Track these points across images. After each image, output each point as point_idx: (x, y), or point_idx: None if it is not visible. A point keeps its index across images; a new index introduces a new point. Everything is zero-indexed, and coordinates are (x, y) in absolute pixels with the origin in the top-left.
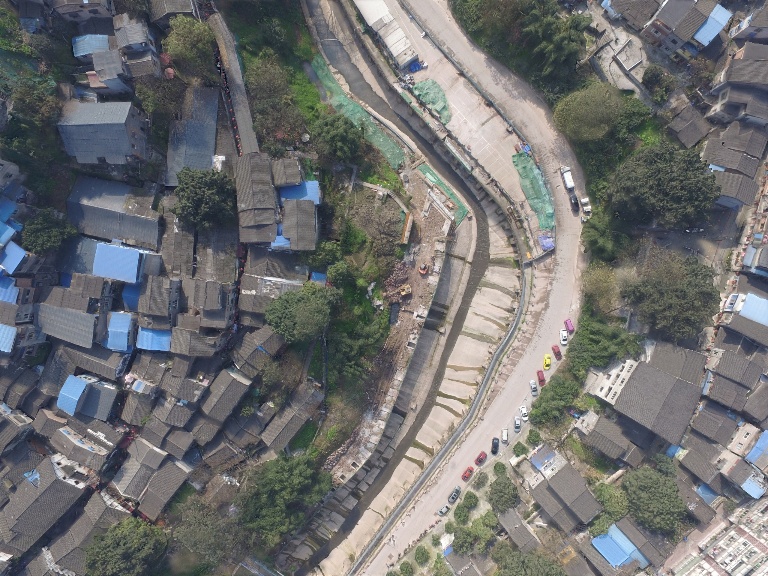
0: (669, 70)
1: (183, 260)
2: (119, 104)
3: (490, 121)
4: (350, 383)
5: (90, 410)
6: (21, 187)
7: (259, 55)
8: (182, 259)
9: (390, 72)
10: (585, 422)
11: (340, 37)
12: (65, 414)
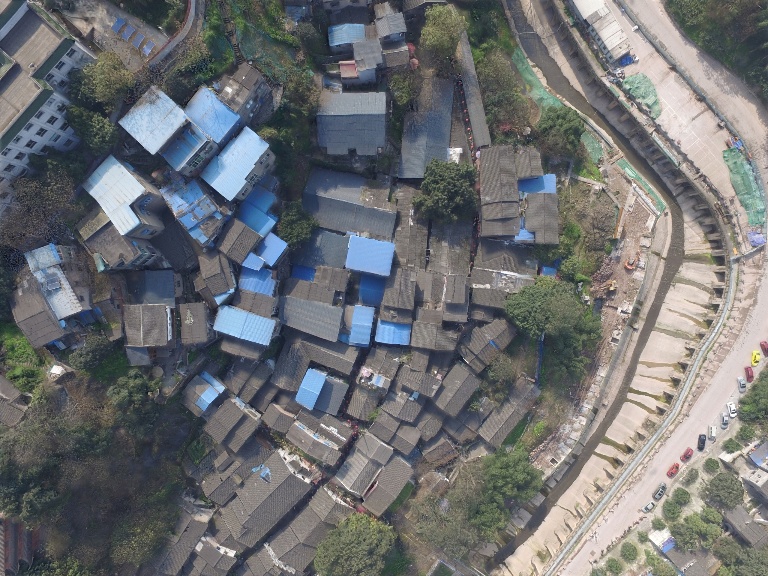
0: None
1: (417, 253)
2: (373, 94)
3: (701, 116)
4: (557, 379)
5: (323, 405)
6: (274, 178)
7: (482, 47)
8: (416, 252)
9: (598, 66)
10: None
11: (538, 30)
12: (292, 409)
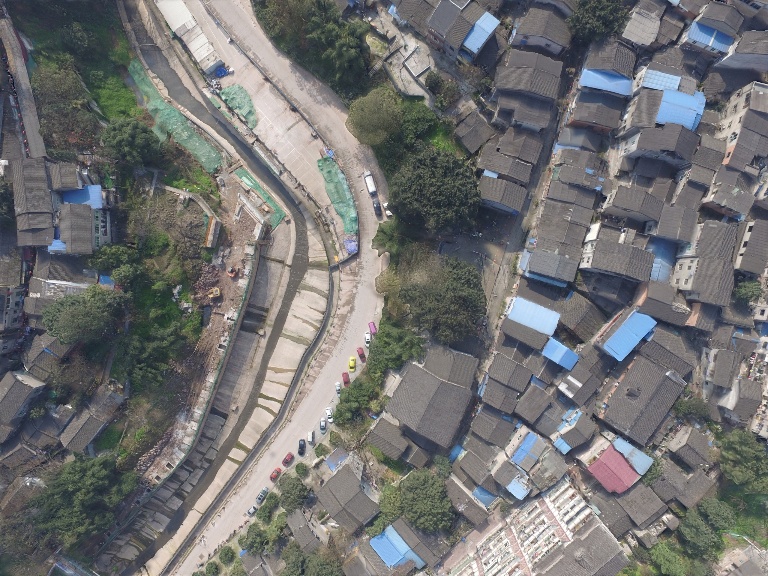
0: (456, 76)
1: None
2: None
3: (296, 126)
4: None
5: None
6: None
7: None
8: None
9: (200, 77)
10: (375, 424)
11: (158, 42)
12: None
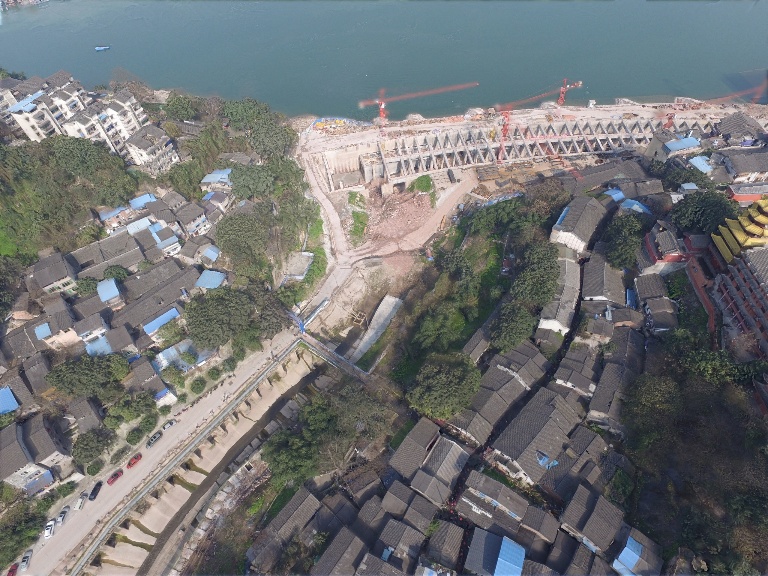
0: None
1: None
2: None
3: None
4: (225, 568)
5: (493, 542)
6: None
7: None
8: None
9: None
10: None
11: None
12: (527, 535)
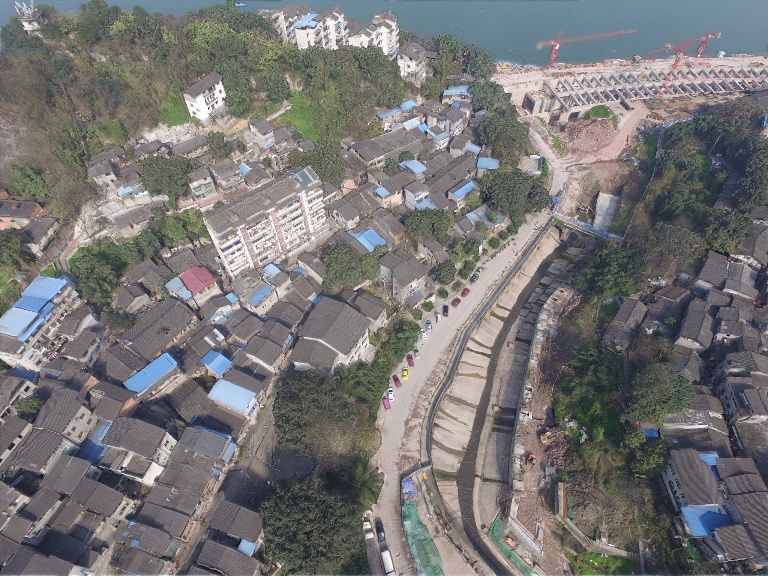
0: None
1: None
2: None
3: None
4: None
5: None
6: None
7: None
8: None
9: None
10: None
11: None
12: None
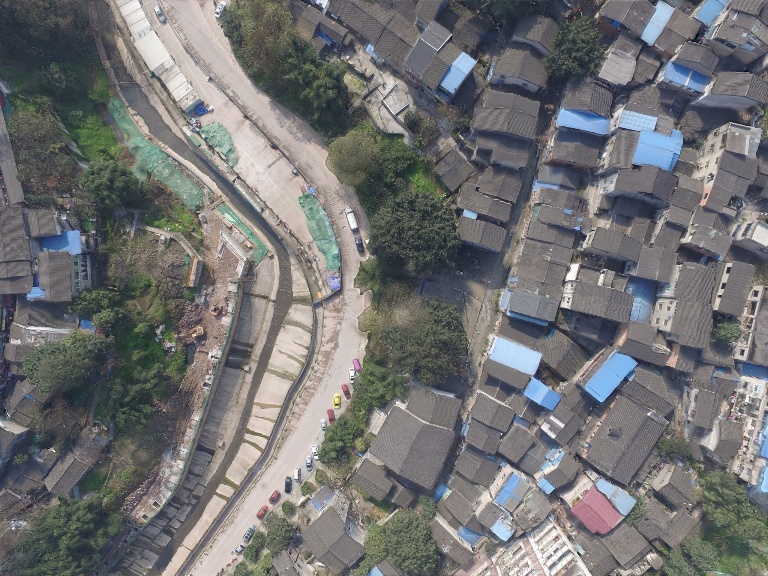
0: (435, 114)
1: None
2: None
3: (276, 163)
4: None
5: None
6: None
7: None
8: None
9: (179, 115)
10: (360, 463)
11: (138, 79)
12: None
